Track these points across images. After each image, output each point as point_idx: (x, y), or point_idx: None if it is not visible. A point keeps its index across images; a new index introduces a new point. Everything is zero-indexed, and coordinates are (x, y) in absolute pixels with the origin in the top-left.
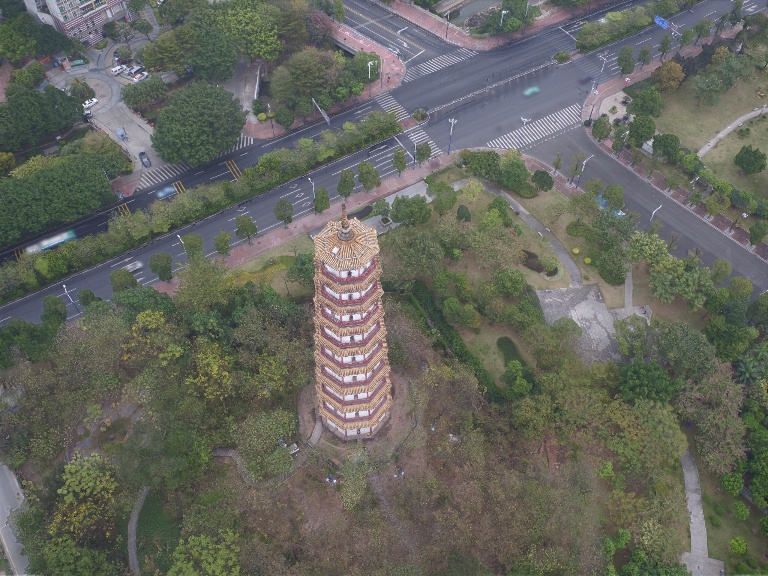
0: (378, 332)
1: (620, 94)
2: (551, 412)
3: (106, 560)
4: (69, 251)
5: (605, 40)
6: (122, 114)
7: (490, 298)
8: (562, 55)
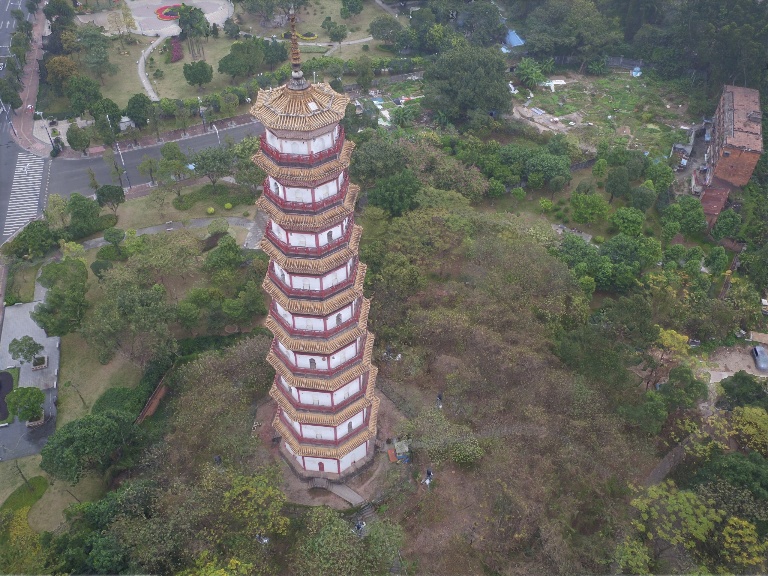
0: None
1: (38, 123)
2: None
3: None
4: None
5: None
6: None
7: None
8: None
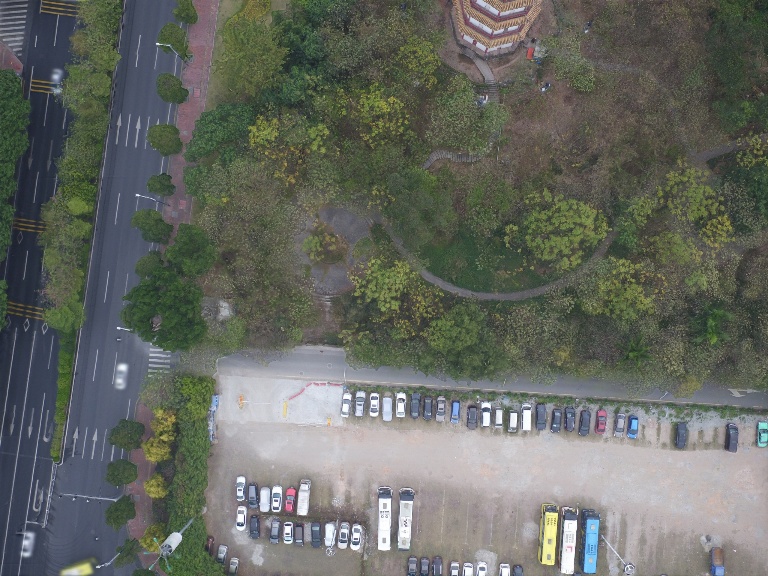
0: None
1: None
2: None
3: None
4: (76, 170)
5: None
6: None
7: None
8: None
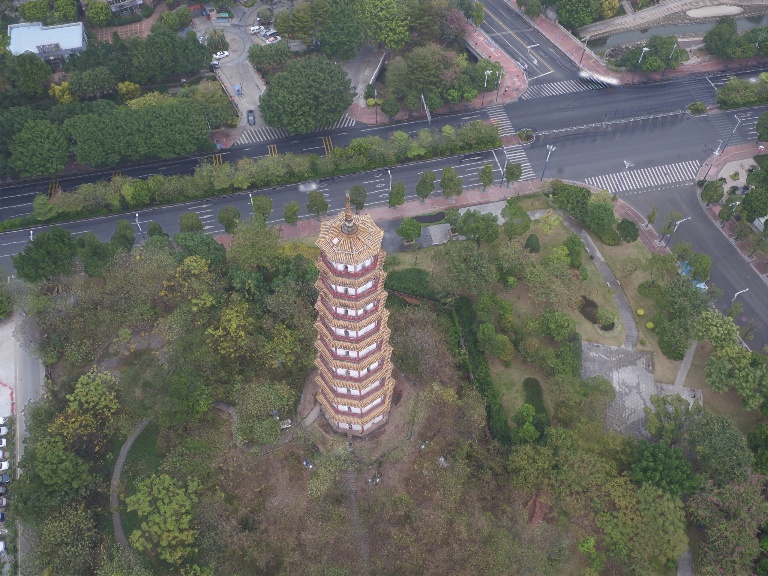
0: (376, 334)
1: (749, 161)
2: (549, 467)
3: (88, 471)
4: (155, 185)
5: (750, 100)
6: (246, 71)
7: (530, 335)
8: (698, 106)
